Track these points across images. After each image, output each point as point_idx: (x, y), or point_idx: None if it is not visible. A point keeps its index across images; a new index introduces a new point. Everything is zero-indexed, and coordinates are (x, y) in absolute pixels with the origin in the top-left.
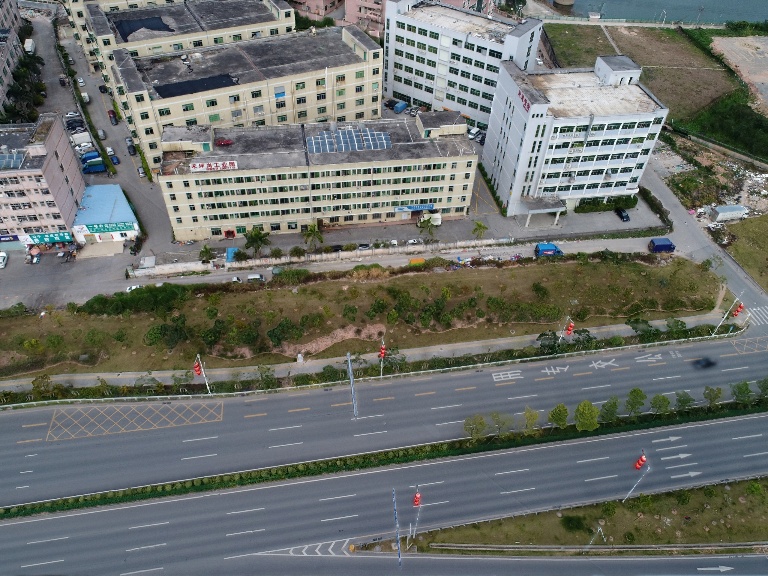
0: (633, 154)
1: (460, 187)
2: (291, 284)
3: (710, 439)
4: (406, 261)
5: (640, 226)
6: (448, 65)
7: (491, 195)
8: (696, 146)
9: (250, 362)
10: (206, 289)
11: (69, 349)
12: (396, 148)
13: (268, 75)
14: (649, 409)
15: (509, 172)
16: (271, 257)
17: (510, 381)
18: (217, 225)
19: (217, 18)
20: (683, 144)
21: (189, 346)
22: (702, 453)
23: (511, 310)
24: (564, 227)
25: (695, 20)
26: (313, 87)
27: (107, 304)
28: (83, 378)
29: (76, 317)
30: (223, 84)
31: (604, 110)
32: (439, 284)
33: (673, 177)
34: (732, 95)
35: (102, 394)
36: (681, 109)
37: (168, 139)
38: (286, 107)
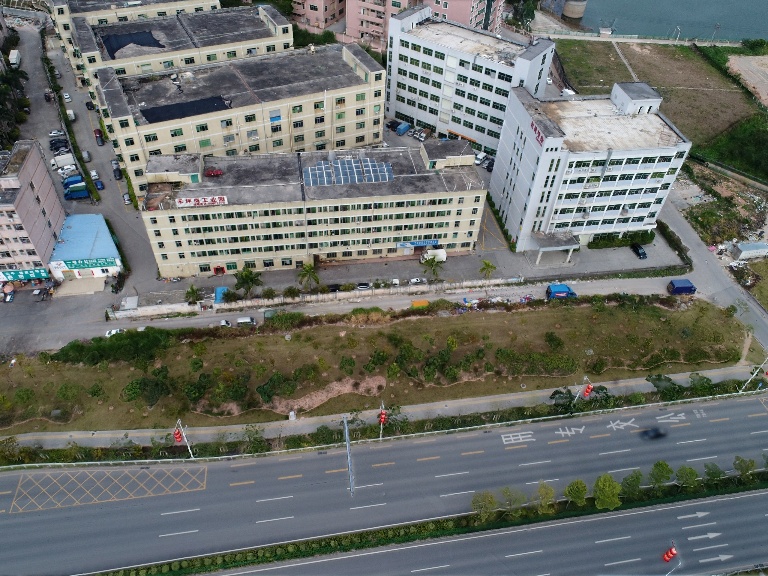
0: (652, 189)
1: (467, 222)
2: (284, 329)
3: (741, 515)
4: (408, 302)
5: (658, 265)
6: (454, 87)
7: (499, 228)
8: (714, 174)
9: (238, 420)
10: (192, 334)
11: (39, 406)
12: (399, 181)
13: (263, 97)
14: (673, 479)
15: (519, 206)
16: (263, 298)
17: (521, 444)
18: (206, 261)
19: (211, 33)
20: (701, 172)
21: (171, 401)
22: (733, 532)
23: (522, 361)
24: (577, 265)
25: (710, 37)
26: (311, 110)
27: (83, 352)
28: (54, 437)
29: (49, 366)
30: (215, 107)
31: (622, 143)
32: (444, 330)
33: (691, 209)
34: (751, 119)
35: (74, 457)
36: (698, 134)
37: (153, 170)
38: (282, 131)
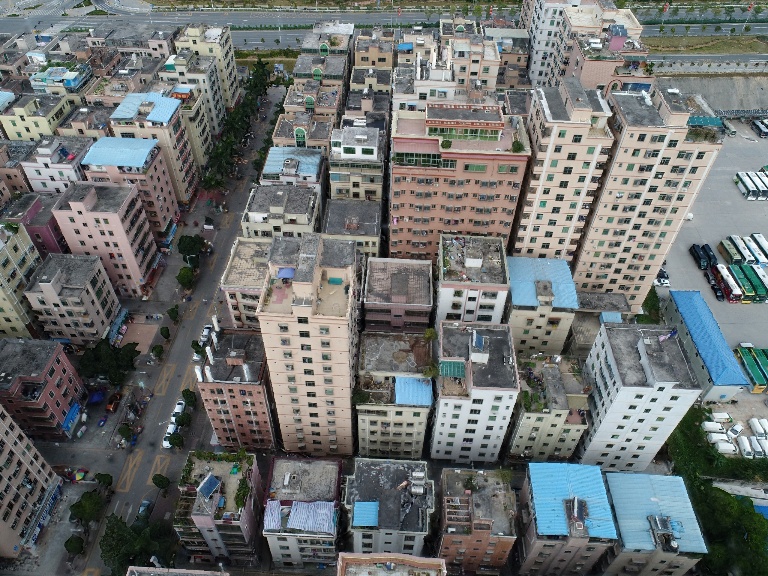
0: None
1: None
2: None
3: None
4: None
5: None
6: None
7: None
8: None
9: (334, 6)
10: None
11: None
12: None
13: None
14: None
15: None
16: None
17: None
18: None
19: None
20: None
21: None
22: None
23: None
24: None
25: None
26: None
27: None
28: (261, 6)
29: None
30: None
31: None
32: None
33: None
34: None
35: (271, 8)
36: None
37: None
38: None
